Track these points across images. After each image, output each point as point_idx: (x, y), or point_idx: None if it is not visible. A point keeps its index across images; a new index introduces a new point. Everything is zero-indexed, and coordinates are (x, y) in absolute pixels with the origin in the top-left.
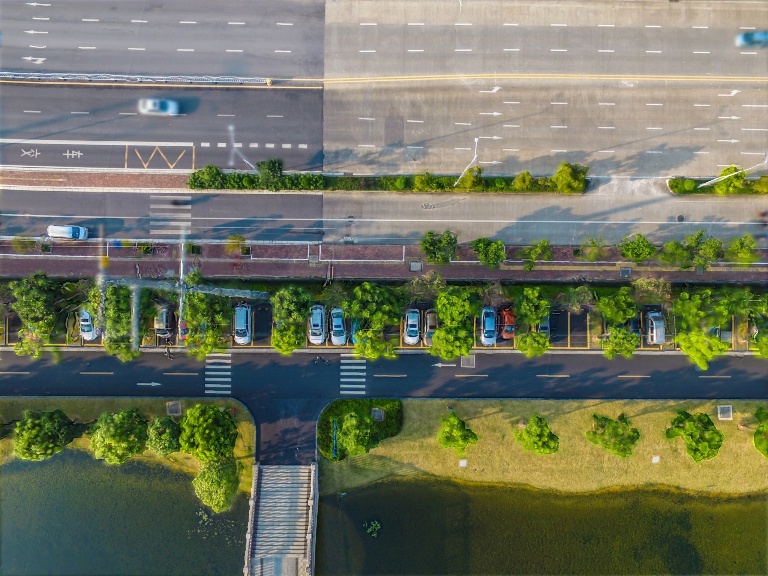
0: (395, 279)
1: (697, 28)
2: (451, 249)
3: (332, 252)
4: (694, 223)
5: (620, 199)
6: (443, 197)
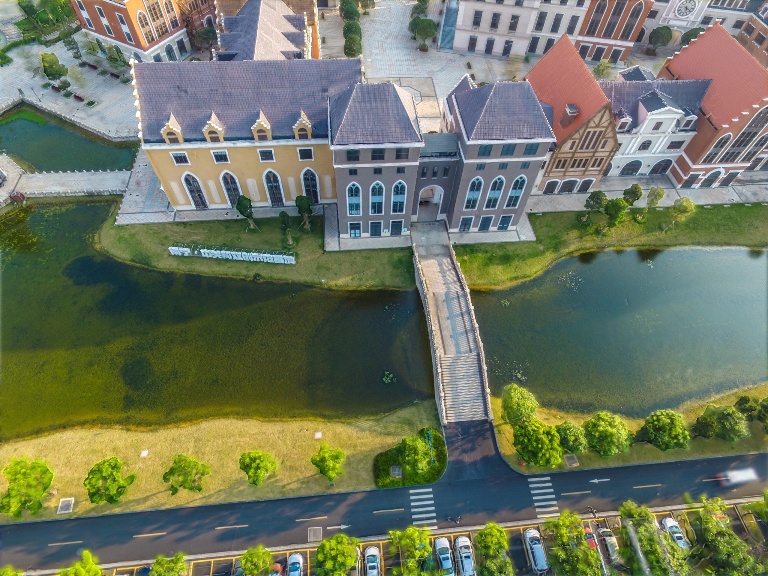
0: None
1: None
2: None
3: None
4: None
5: None
6: None
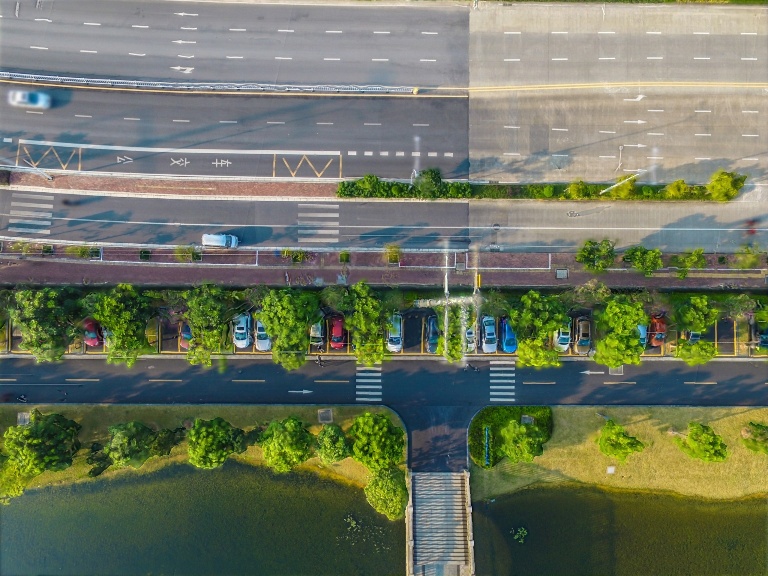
0: (542, 287)
1: None
2: (610, 257)
3: (479, 260)
4: None
5: (764, 207)
6: (588, 205)
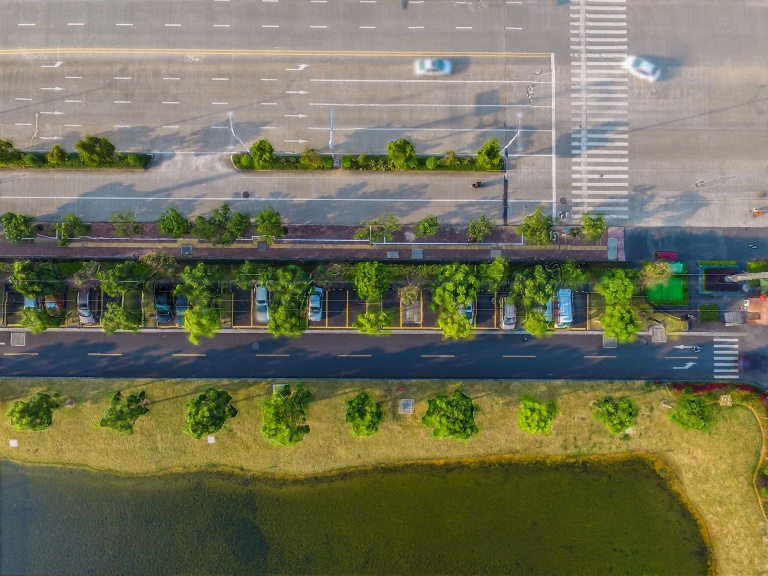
0: None
1: (267, 2)
2: None
3: None
4: (260, 199)
5: (184, 175)
6: (2, 173)
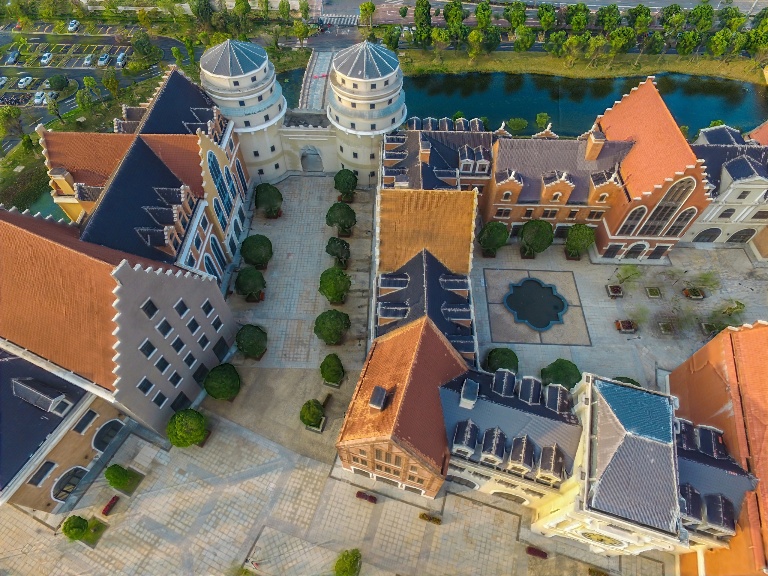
0: None
1: None
2: None
3: None
4: None
5: None
6: None
